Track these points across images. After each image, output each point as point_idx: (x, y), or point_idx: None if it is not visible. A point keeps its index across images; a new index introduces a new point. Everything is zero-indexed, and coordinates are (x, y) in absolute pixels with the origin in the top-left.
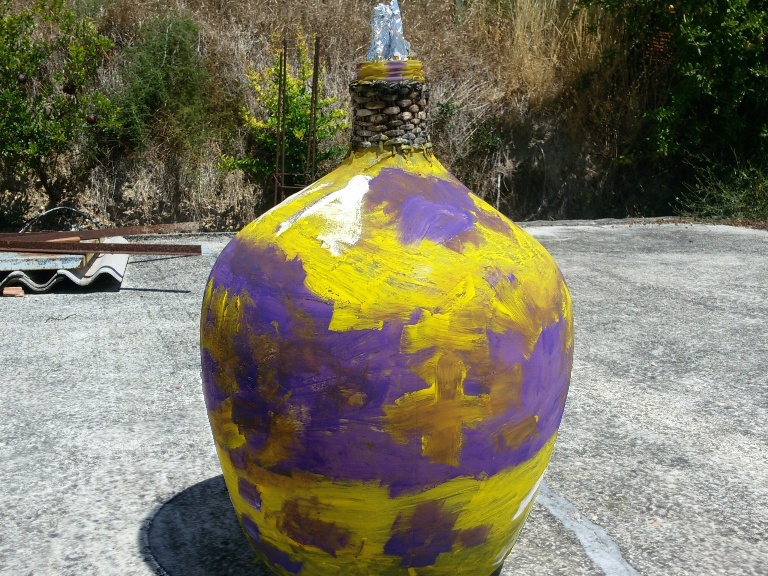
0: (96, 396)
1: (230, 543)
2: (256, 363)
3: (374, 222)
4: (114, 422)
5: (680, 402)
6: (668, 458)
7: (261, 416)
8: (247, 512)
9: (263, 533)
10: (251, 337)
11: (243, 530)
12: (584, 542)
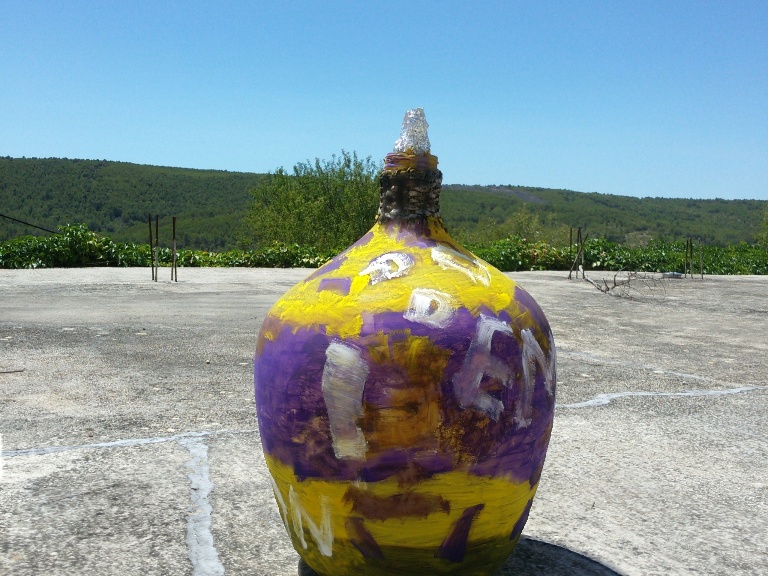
0: None
1: (536, 567)
2: None
3: None
4: None
5: None
6: None
7: None
8: None
9: None
10: None
11: None
12: None
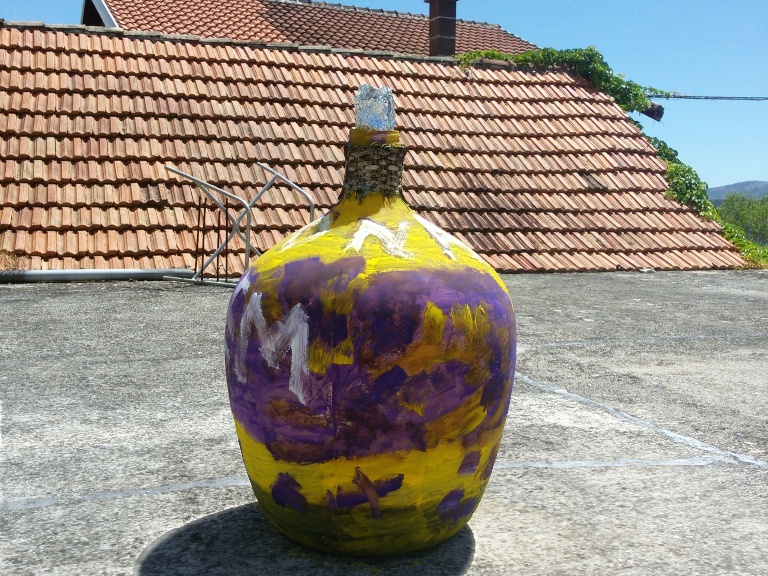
0: None
1: None
2: (501, 348)
3: None
4: None
5: (78, 427)
6: (204, 442)
7: (500, 387)
8: (459, 485)
9: (467, 493)
10: (497, 331)
11: (408, 530)
12: None
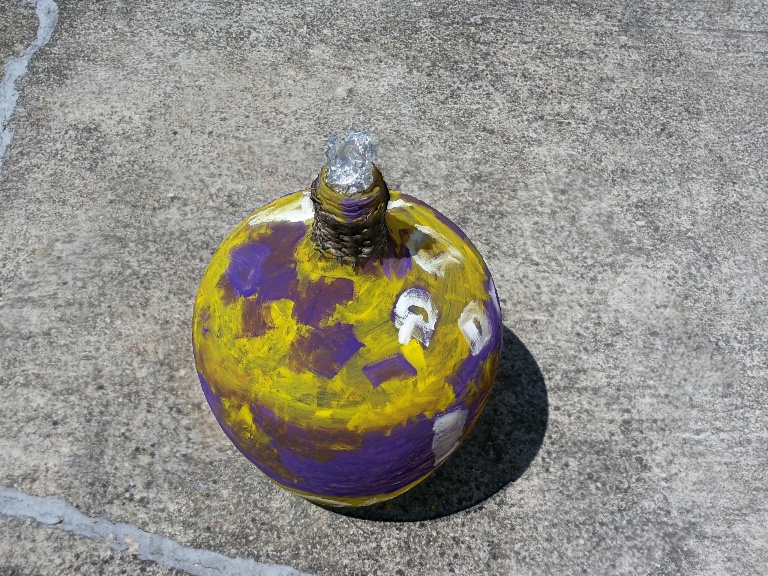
0: (767, 285)
1: None
2: None
3: (255, 229)
4: (684, 295)
5: None
6: None
7: None
8: None
9: None
10: None
11: None
12: (307, 575)
